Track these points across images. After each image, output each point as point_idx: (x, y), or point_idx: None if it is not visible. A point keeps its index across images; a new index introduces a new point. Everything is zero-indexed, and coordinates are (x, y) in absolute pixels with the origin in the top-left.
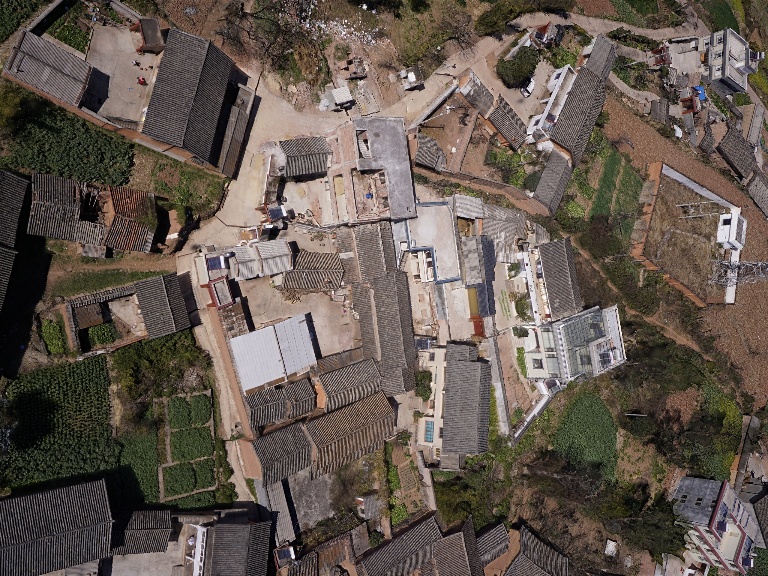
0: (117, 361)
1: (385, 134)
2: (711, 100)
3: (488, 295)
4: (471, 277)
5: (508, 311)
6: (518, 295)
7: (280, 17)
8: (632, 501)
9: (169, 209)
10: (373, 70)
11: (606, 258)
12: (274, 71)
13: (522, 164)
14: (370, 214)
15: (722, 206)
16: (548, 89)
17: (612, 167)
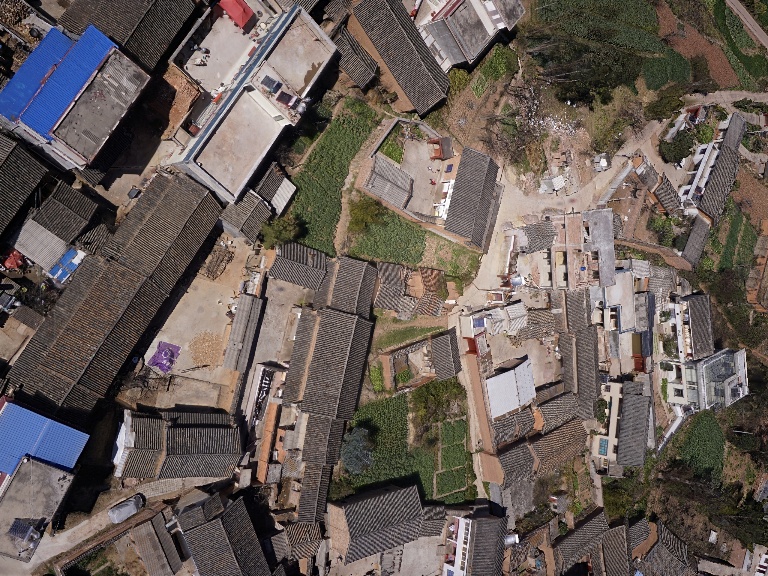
0: (415, 396)
1: (601, 222)
2: None
3: (650, 339)
4: (640, 326)
5: (657, 349)
6: (665, 336)
7: (516, 120)
8: None
9: (448, 281)
10: (576, 158)
11: (728, 303)
12: (511, 164)
13: (672, 227)
14: (583, 283)
15: None
16: (693, 161)
17: (736, 225)
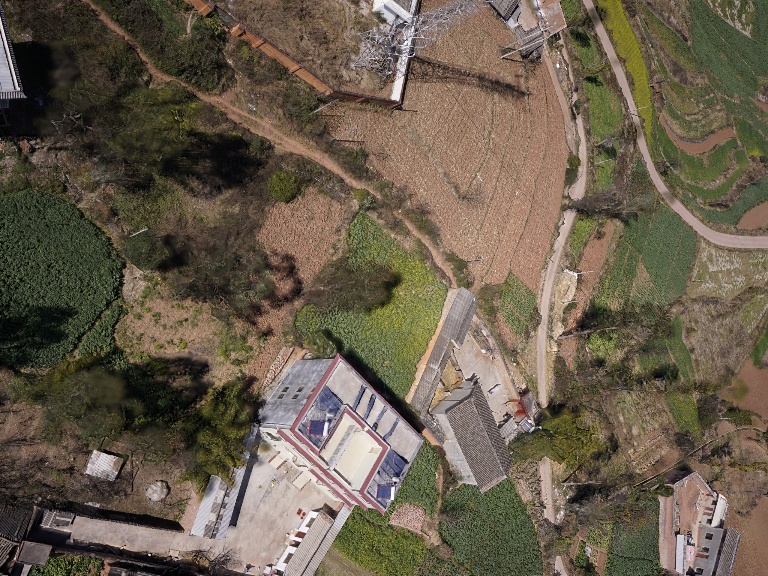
0: None
1: None
2: None
3: None
4: None
5: None
6: None
7: None
8: (159, 388)
9: None
10: None
11: None
12: None
13: None
14: None
15: None
16: None
17: None
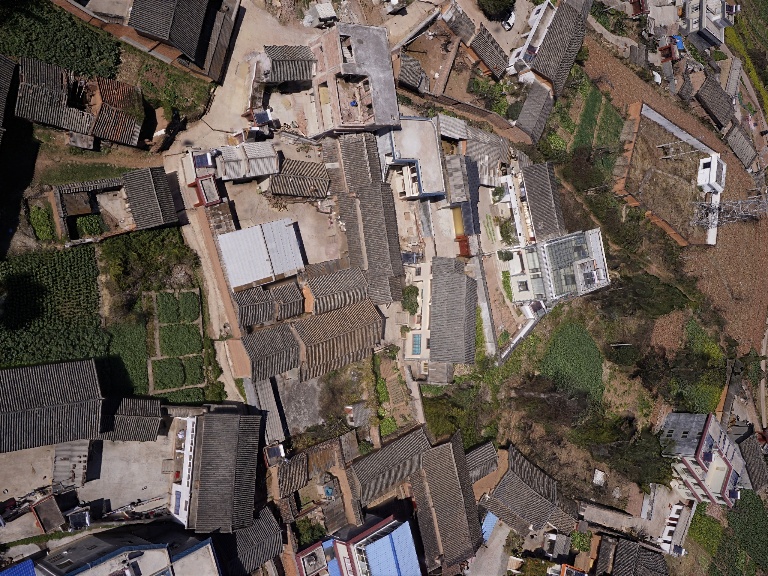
0: (105, 251)
1: (368, 42)
2: (689, 52)
3: (473, 214)
4: (456, 195)
5: (493, 235)
6: (502, 220)
7: None
8: (619, 432)
9: (156, 107)
10: None
11: (589, 191)
12: None
13: (504, 95)
14: (355, 121)
15: (702, 152)
16: (529, 24)
17: (593, 104)
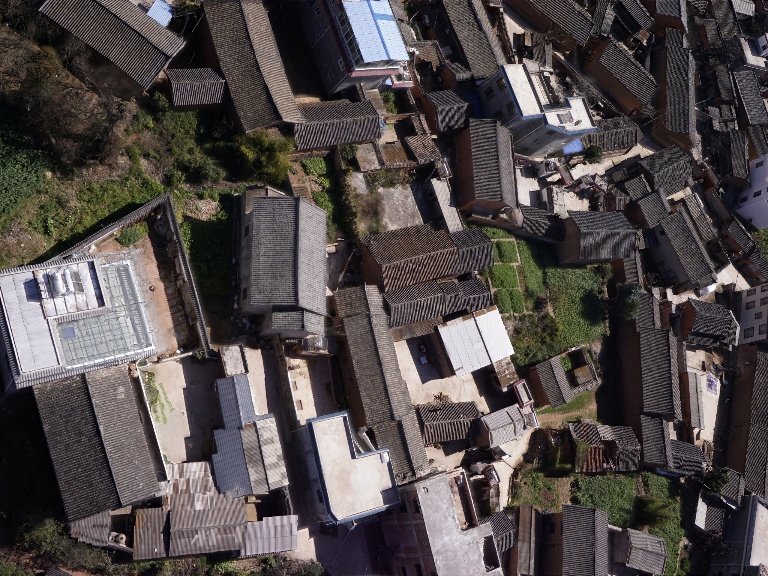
0: None
1: None
2: None
3: (237, 406)
4: (270, 429)
5: None
6: None
7: None
8: None
9: None
10: None
11: None
12: None
13: None
14: None
15: None
16: None
17: None
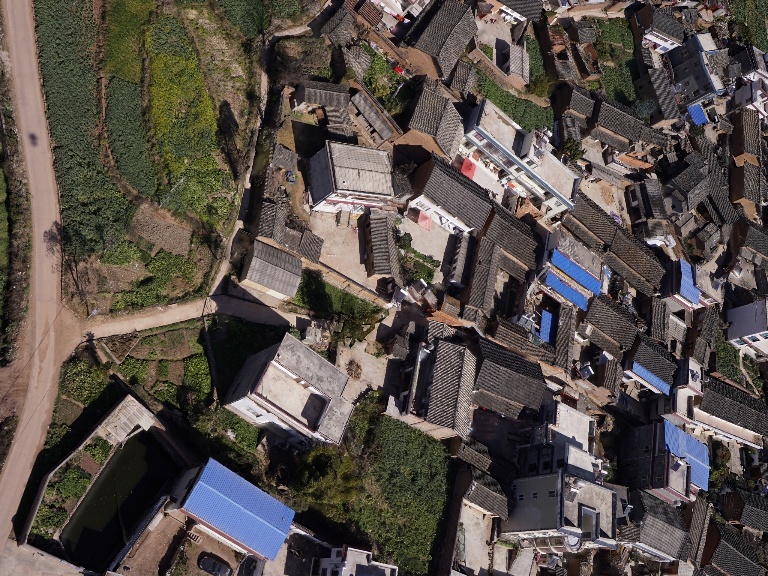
0: None
1: None
2: None
3: None
4: None
5: None
6: None
7: None
8: None
9: None
10: None
11: None
12: None
13: None
14: None
15: None
16: None
17: None
